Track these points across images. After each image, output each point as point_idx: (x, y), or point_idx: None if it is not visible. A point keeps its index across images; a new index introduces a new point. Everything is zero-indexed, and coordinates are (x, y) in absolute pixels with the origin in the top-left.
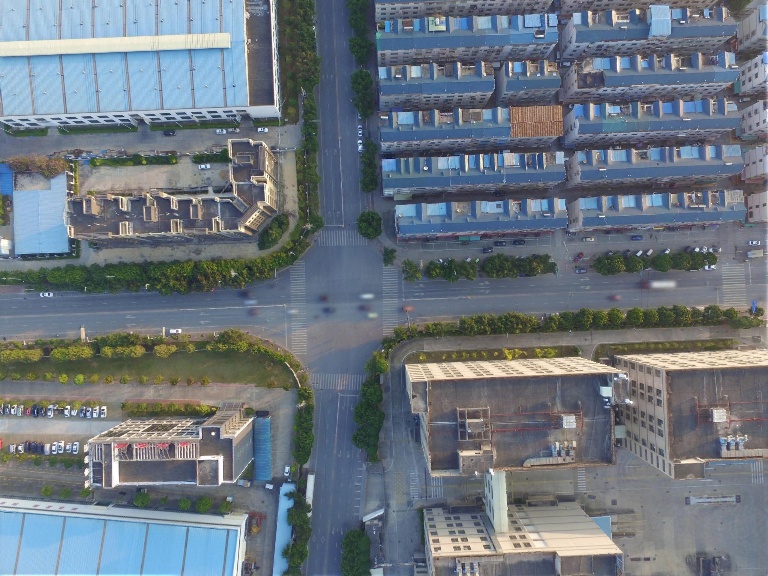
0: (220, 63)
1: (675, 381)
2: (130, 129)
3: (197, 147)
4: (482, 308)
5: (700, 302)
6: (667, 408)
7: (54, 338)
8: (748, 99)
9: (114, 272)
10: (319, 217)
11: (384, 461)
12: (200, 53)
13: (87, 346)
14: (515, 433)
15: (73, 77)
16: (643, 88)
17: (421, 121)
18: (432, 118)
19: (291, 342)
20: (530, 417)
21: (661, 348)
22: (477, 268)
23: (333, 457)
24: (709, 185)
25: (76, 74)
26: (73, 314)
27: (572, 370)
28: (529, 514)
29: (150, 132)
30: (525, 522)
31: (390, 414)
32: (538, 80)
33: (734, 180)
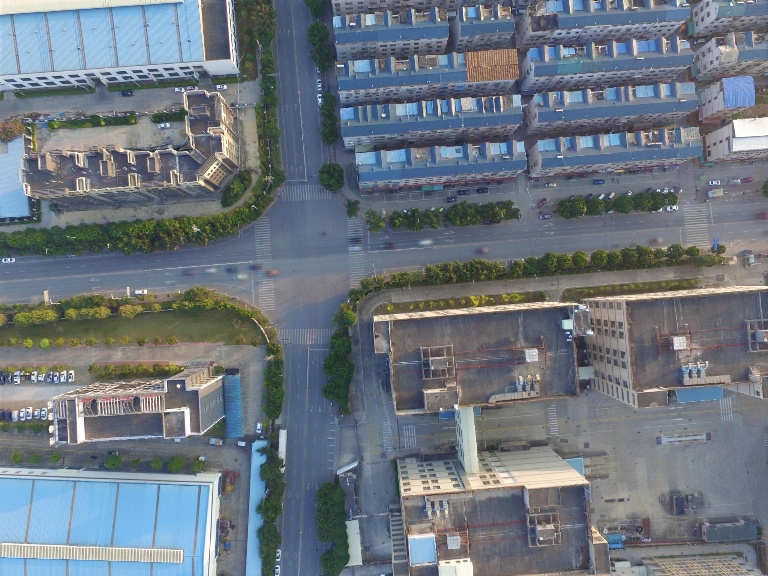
0: (174, 18)
1: (636, 312)
2: (87, 90)
3: (156, 106)
4: (448, 257)
5: (663, 243)
6: (628, 338)
7: (17, 303)
8: (703, 41)
9: (75, 233)
10: (281, 171)
11: (356, 414)
12: (153, 9)
13: (51, 309)
14: (479, 370)
15: (25, 37)
16: (597, 30)
17: (377, 68)
18: (388, 65)
19: (258, 299)
20: (494, 353)
21: (627, 290)
22: (441, 218)
23: (305, 412)
24: (668, 127)
25: (28, 34)
26: (36, 279)
27: (534, 306)
28: (501, 458)
29: (108, 93)
30: (496, 464)
31: (360, 367)
32: (492, 24)
33: (692, 121)
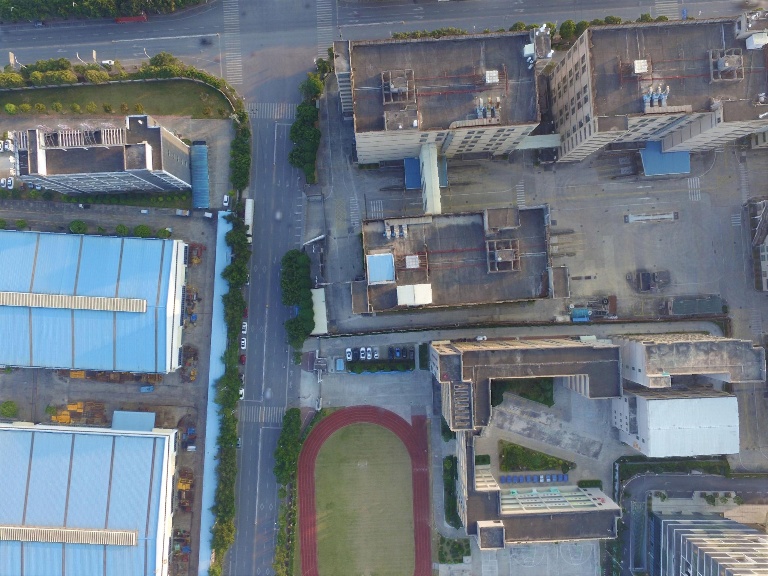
0: None
1: (598, 42)
2: None
3: None
4: None
5: None
6: (590, 65)
7: None
8: None
9: None
10: None
11: (323, 188)
12: None
13: (17, 73)
14: (440, 97)
15: None
16: None
17: None
18: None
19: (226, 72)
20: (455, 81)
21: None
22: None
23: (272, 187)
24: None
25: None
26: (3, 49)
27: None
28: None
29: None
30: None
31: (328, 141)
32: None
33: None
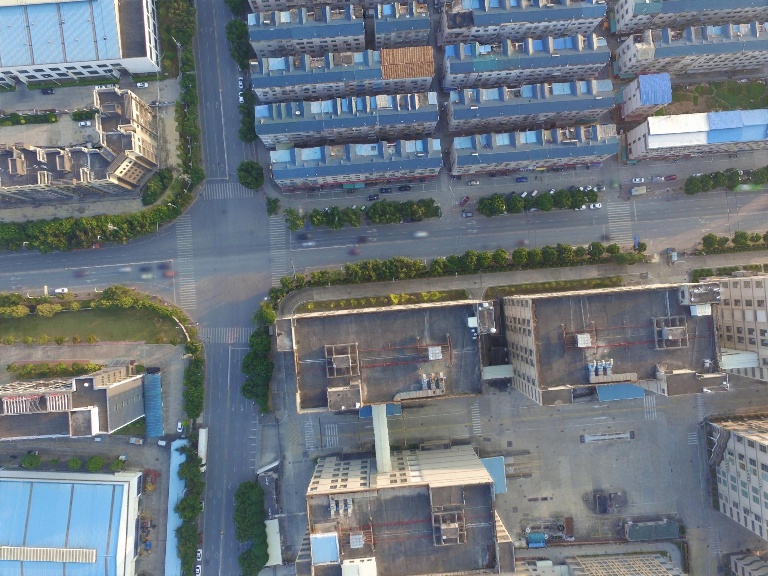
0: (89, 16)
1: (542, 310)
2: (7, 88)
3: (77, 105)
4: (370, 255)
5: (587, 241)
6: (534, 336)
7: None
8: (626, 38)
9: None
10: (200, 169)
11: (278, 413)
12: (68, 6)
13: None
14: (385, 368)
15: None
16: (515, 27)
17: (292, 66)
18: (303, 63)
19: (180, 297)
20: (399, 351)
21: (550, 288)
22: (364, 216)
23: (227, 411)
24: None
25: None
26: None
27: (442, 304)
28: (419, 457)
29: (28, 91)
30: (412, 463)
31: (282, 365)
32: (407, 21)
33: (616, 119)
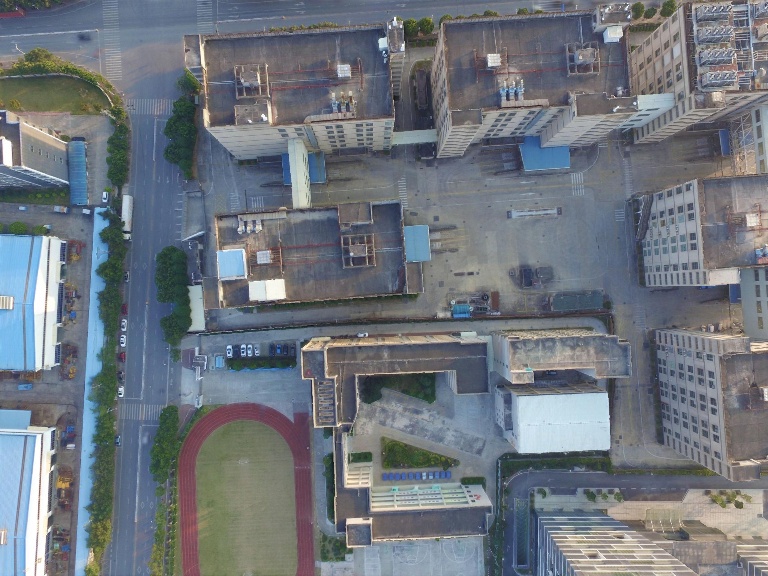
0: None
1: (454, 35)
2: None
3: None
4: None
5: None
6: (445, 59)
7: None
8: None
9: None
10: None
11: (204, 184)
12: None
13: None
14: (295, 91)
15: None
16: None
17: None
18: None
19: (105, 68)
20: (310, 75)
21: None
22: None
23: (152, 183)
24: None
25: None
26: None
27: None
28: None
29: None
30: None
31: (208, 137)
32: None
33: None
